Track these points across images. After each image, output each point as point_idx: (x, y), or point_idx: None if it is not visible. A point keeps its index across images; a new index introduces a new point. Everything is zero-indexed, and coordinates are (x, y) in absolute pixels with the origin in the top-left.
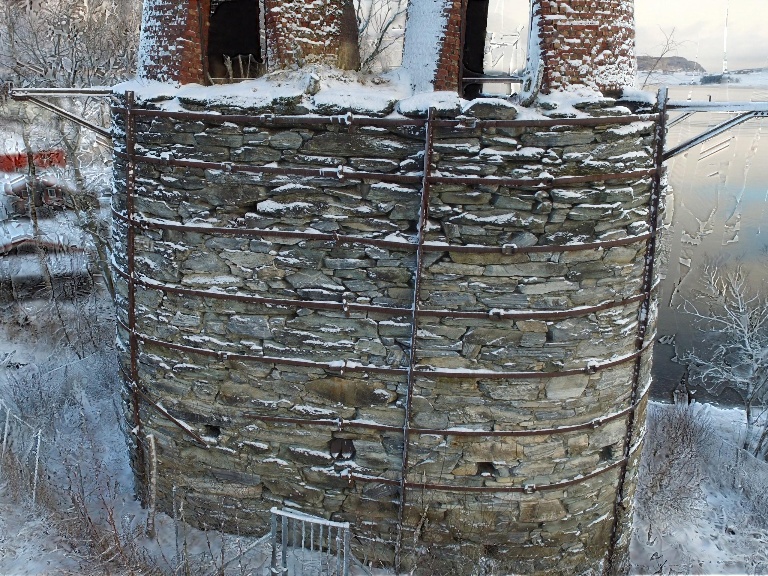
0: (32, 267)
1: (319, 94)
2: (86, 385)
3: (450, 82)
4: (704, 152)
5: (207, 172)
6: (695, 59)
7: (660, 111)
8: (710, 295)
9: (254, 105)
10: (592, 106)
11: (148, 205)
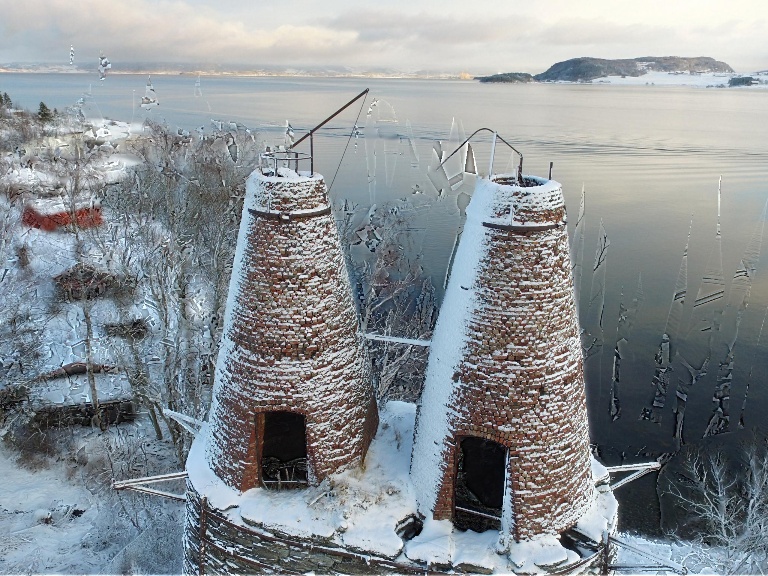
0: (97, 458)
1: (347, 535)
2: (141, 561)
3: (446, 510)
4: (699, 300)
5: (262, 569)
6: (691, 217)
7: (605, 545)
8: (692, 479)
9: (298, 535)
10: (549, 567)
11: (215, 575)
